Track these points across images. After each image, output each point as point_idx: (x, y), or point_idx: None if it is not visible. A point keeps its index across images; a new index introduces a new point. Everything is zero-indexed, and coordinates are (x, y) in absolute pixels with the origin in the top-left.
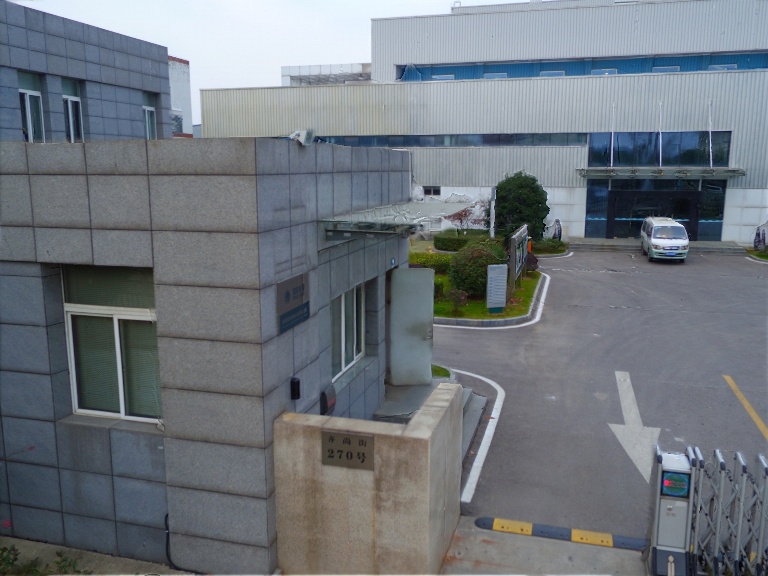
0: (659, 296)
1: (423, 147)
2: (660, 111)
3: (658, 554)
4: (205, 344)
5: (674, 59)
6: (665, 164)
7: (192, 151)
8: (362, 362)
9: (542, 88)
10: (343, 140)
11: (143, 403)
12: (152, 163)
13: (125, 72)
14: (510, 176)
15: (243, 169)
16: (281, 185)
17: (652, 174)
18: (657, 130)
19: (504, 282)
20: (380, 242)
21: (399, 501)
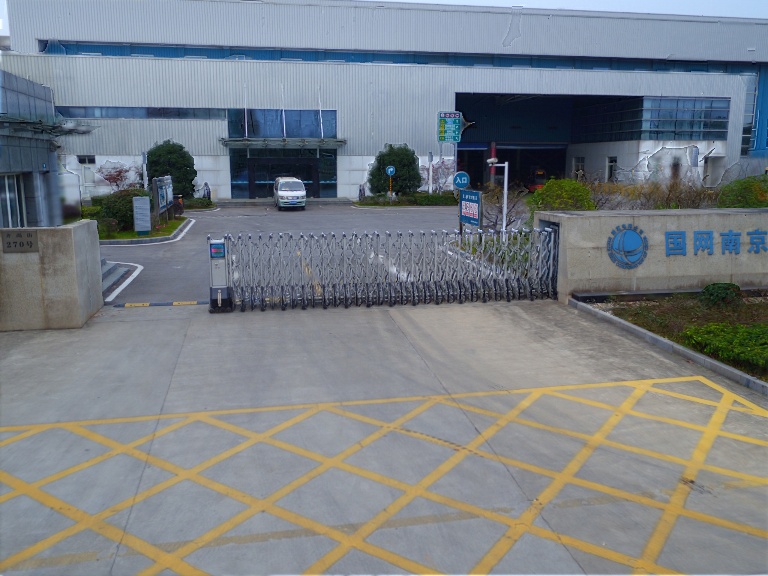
0: (276, 225)
1: (73, 118)
2: (282, 92)
3: (213, 290)
4: None
5: (297, 53)
6: (290, 136)
7: None
8: None
9: (183, 68)
10: None
11: None
12: None
13: None
14: (159, 144)
15: None
16: None
17: (279, 143)
18: (281, 108)
19: (148, 210)
20: (32, 147)
21: (57, 268)
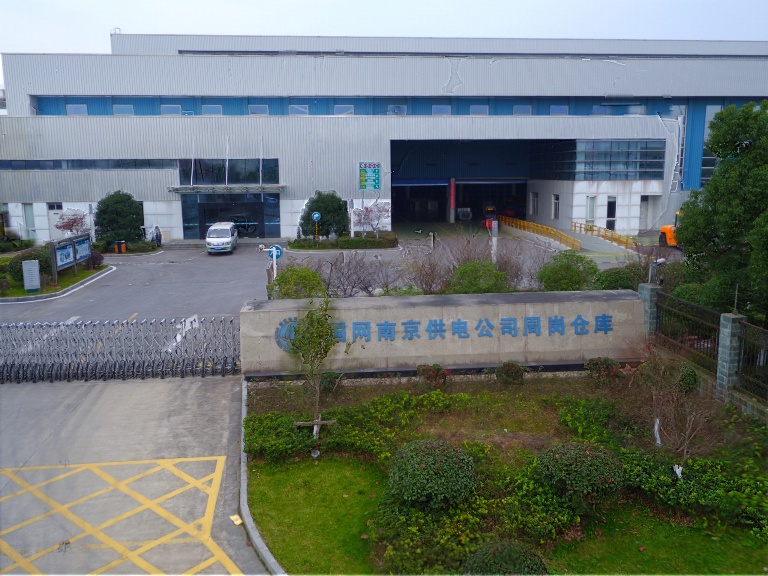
0: (173, 276)
1: (43, 170)
2: (227, 144)
3: None
4: None
5: (263, 99)
6: (235, 183)
7: None
8: None
9: (138, 124)
10: None
11: None
12: None
13: None
14: (111, 194)
15: None
16: None
17: None
18: None
19: (37, 272)
20: None
21: None
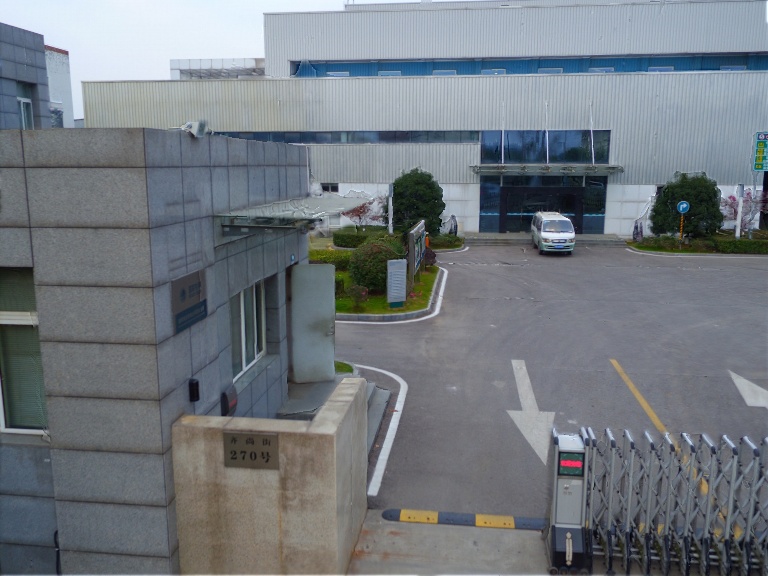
0: (550, 287)
1: (320, 144)
2: (546, 110)
3: (557, 532)
4: (94, 347)
5: (557, 61)
6: (552, 161)
7: (74, 142)
8: (263, 361)
9: (435, 86)
10: (237, 136)
11: (26, 414)
12: (28, 155)
13: None
14: (407, 173)
15: (131, 161)
16: (173, 178)
17: (540, 171)
18: (544, 129)
19: (404, 277)
20: (279, 238)
21: (306, 499)
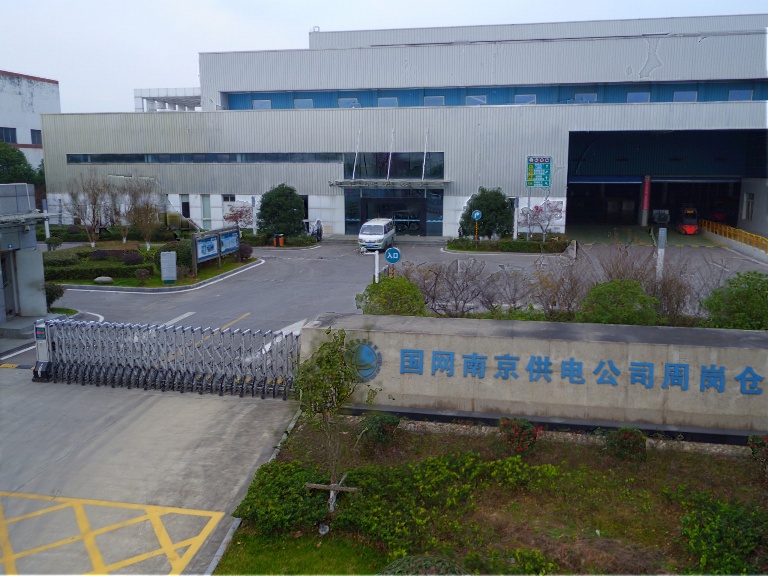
0: None
1: (220, 163)
2: (392, 137)
3: (38, 363)
4: None
5: (440, 90)
6: (398, 177)
7: None
8: None
9: (307, 117)
10: (157, 157)
11: None
12: None
13: None
14: (276, 187)
15: None
16: None
17: (380, 185)
18: (392, 151)
19: (174, 263)
20: None
21: None
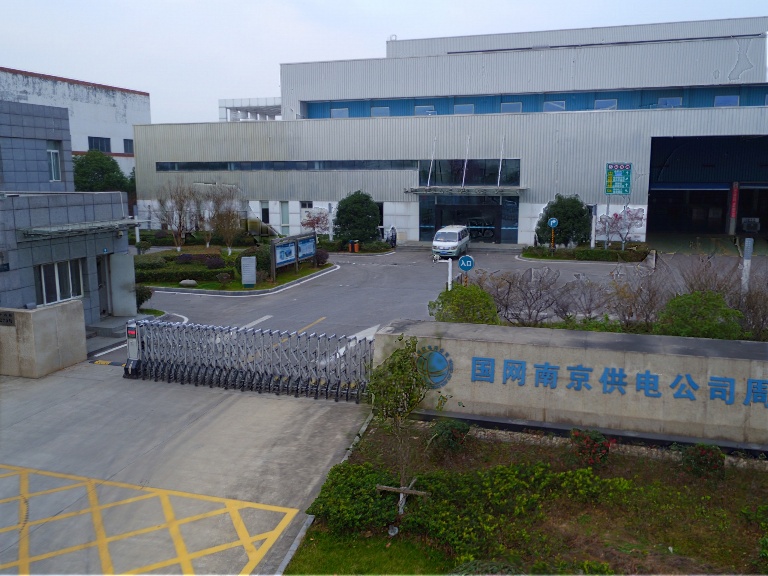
0: None
1: (299, 170)
2: (468, 144)
3: None
4: None
5: (517, 97)
6: (473, 184)
7: None
8: None
9: (383, 125)
10: (240, 165)
11: None
12: None
13: (32, 128)
14: (352, 194)
15: None
16: None
17: (455, 192)
18: (467, 158)
19: (253, 268)
20: (88, 240)
21: (24, 338)
